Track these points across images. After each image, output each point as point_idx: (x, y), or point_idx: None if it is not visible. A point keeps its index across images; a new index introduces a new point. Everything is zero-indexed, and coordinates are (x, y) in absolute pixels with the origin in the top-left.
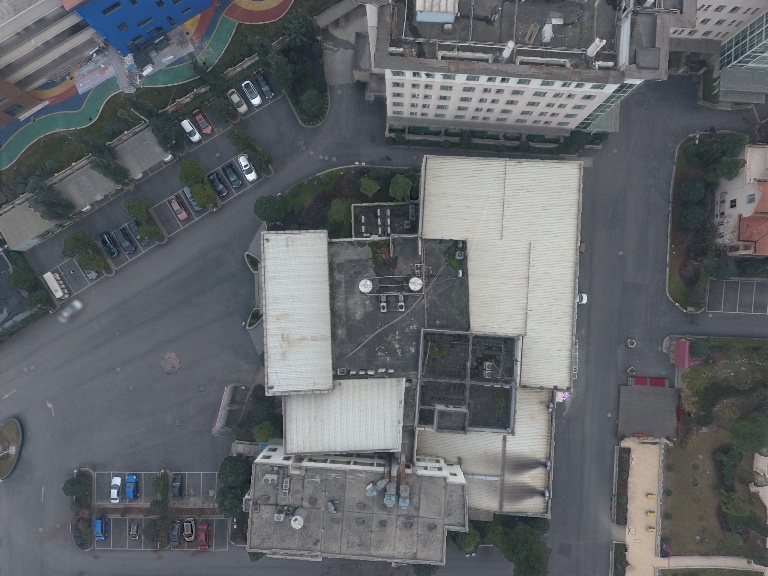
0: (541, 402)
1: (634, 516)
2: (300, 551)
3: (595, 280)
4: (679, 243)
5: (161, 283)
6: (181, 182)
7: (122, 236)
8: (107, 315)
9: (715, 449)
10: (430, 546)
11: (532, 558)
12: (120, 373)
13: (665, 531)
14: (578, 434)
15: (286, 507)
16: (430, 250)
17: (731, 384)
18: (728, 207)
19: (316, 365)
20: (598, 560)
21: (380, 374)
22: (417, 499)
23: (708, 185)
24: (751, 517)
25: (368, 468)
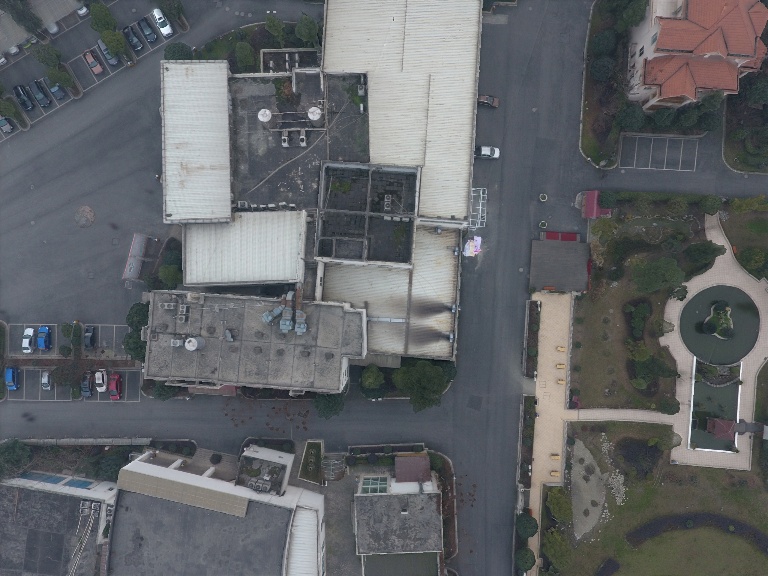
0: (448, 247)
1: (544, 369)
2: (197, 379)
3: (508, 136)
4: (592, 99)
5: (76, 137)
6: (97, 37)
7: (36, 87)
8: (22, 169)
9: (625, 303)
10: (327, 375)
11: (424, 379)
12: (34, 226)
13: (575, 384)
14: (490, 288)
15: (184, 335)
16: (333, 87)
17: (642, 239)
18: (637, 57)
19: (215, 194)
20: (508, 413)
21: (281, 208)
22: (315, 329)
23: (620, 38)
24: (656, 362)
25: (266, 298)
